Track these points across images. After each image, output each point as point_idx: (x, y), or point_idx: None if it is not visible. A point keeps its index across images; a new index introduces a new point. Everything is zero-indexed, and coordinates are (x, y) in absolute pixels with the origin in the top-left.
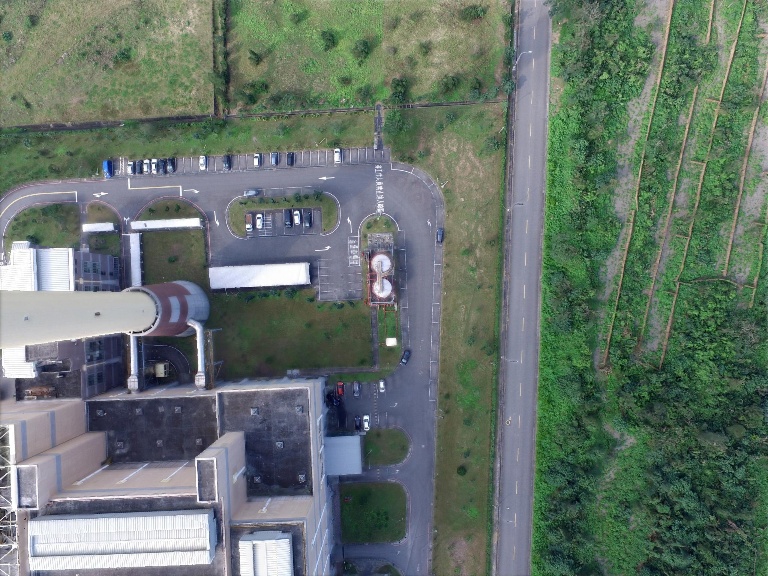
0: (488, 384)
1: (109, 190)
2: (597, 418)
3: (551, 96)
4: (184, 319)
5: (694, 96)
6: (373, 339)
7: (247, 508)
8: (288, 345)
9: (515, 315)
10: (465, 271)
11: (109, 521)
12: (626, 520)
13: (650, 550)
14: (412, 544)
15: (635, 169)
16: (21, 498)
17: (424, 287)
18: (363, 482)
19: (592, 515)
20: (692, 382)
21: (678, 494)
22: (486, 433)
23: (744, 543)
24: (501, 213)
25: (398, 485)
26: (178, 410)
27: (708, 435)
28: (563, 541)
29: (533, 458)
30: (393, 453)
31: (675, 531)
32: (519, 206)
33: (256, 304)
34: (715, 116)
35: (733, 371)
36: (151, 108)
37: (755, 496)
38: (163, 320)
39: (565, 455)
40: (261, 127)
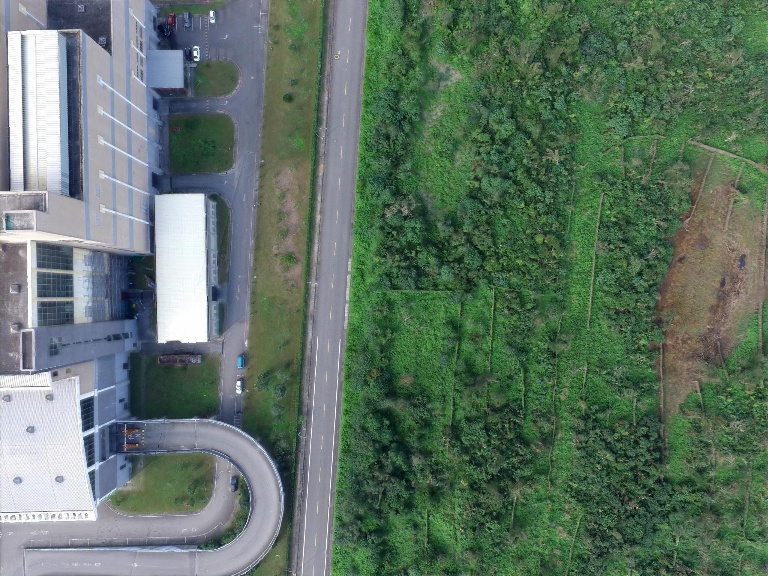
0: (317, 17)
1: None
2: (423, 51)
3: None
4: None
5: None
6: None
7: None
8: None
9: None
10: None
11: None
12: (450, 155)
13: (471, 179)
14: (239, 174)
15: None
16: None
17: None
18: (192, 113)
19: (418, 151)
20: (516, 16)
21: (498, 121)
22: (314, 65)
23: (561, 172)
24: None
25: (227, 116)
26: None
27: None
28: None
29: (360, 92)
30: (222, 84)
31: (492, 154)
32: None
33: None
34: None
35: None
36: None
37: (576, 133)
38: None
39: (390, 84)
40: None
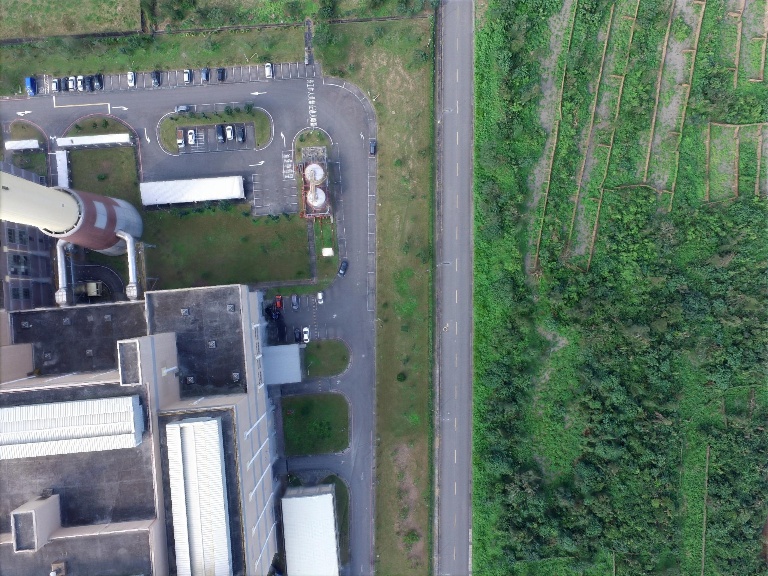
0: (425, 292)
1: (33, 108)
2: (530, 321)
3: (476, 12)
4: (112, 229)
5: (611, 13)
6: (310, 252)
7: (178, 404)
8: (225, 261)
9: (449, 224)
10: (399, 182)
11: (28, 409)
12: (561, 419)
13: (584, 445)
14: (355, 453)
15: (558, 82)
16: None
17: (359, 199)
18: (305, 394)
19: (529, 416)
20: (617, 282)
21: (608, 389)
22: (424, 340)
23: (671, 433)
24: (431, 124)
25: (340, 395)
26: (108, 318)
27: (632, 328)
28: (501, 440)
29: (471, 363)
30: (334, 364)
31: (606, 424)
32: (449, 118)
33: (190, 220)
34: (631, 32)
35: (655, 271)
36: (75, 24)
37: (680, 390)
38: (87, 221)
39: (501, 357)
40: (190, 43)
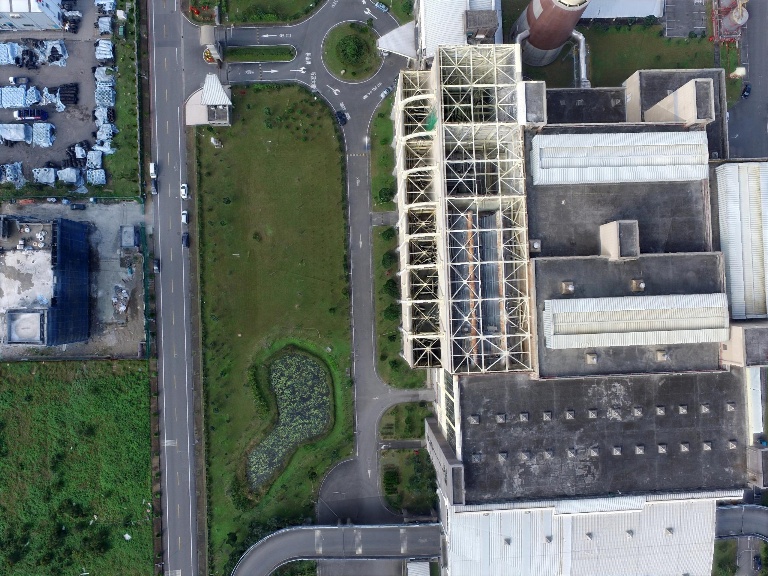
0: None
1: None
2: None
3: None
4: None
5: None
6: None
7: None
8: None
9: None
10: None
11: (614, 136)
12: None
13: None
14: None
15: None
16: (527, 114)
17: (762, 27)
18: None
19: None
20: None
21: None
22: None
23: None
24: None
25: None
26: (582, 101)
27: None
28: None
29: None
30: None
31: None
32: None
33: (607, 37)
34: None
35: None
36: None
37: None
38: None
39: None
40: None
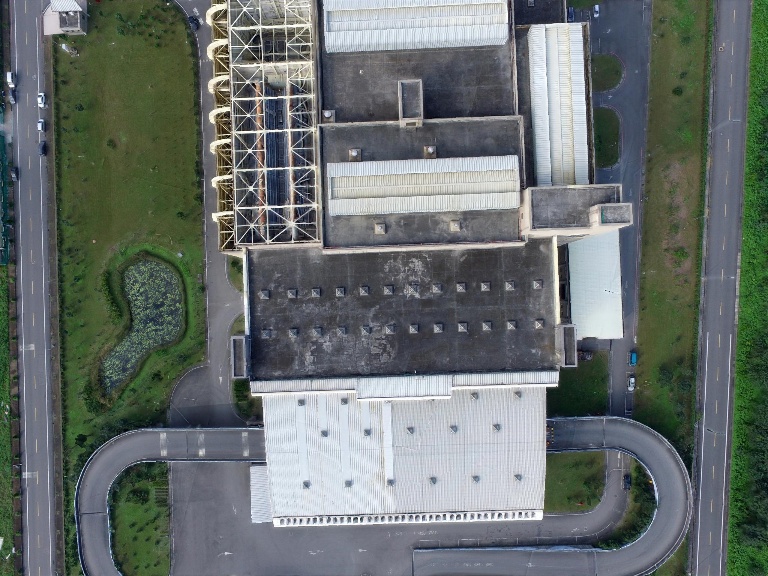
0: (703, 9)
1: None
2: None
3: None
4: None
5: None
6: None
7: None
8: None
9: None
10: None
11: None
12: None
13: None
14: (624, 169)
15: None
16: None
17: None
18: None
19: None
20: None
21: None
22: (700, 58)
23: None
24: None
25: (611, 111)
26: None
27: None
28: None
29: (746, 84)
30: (606, 78)
31: None
32: None
33: None
34: None
35: None
36: None
37: None
38: None
39: None
40: None
